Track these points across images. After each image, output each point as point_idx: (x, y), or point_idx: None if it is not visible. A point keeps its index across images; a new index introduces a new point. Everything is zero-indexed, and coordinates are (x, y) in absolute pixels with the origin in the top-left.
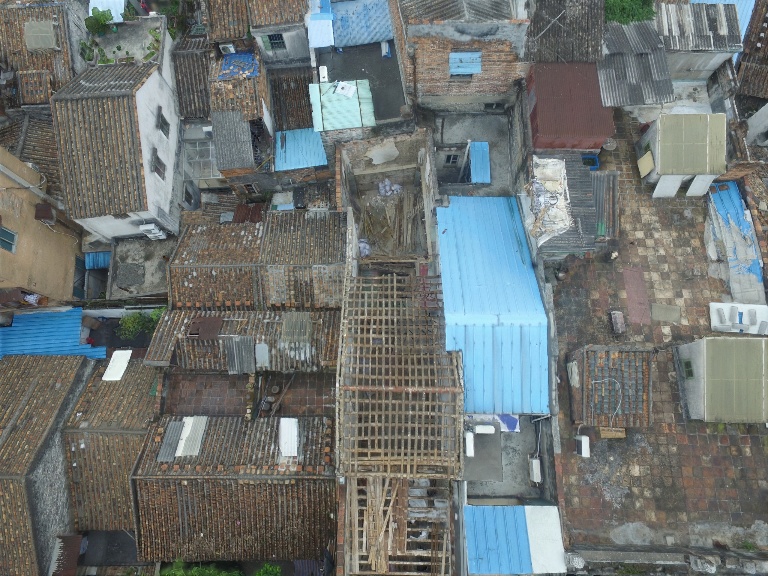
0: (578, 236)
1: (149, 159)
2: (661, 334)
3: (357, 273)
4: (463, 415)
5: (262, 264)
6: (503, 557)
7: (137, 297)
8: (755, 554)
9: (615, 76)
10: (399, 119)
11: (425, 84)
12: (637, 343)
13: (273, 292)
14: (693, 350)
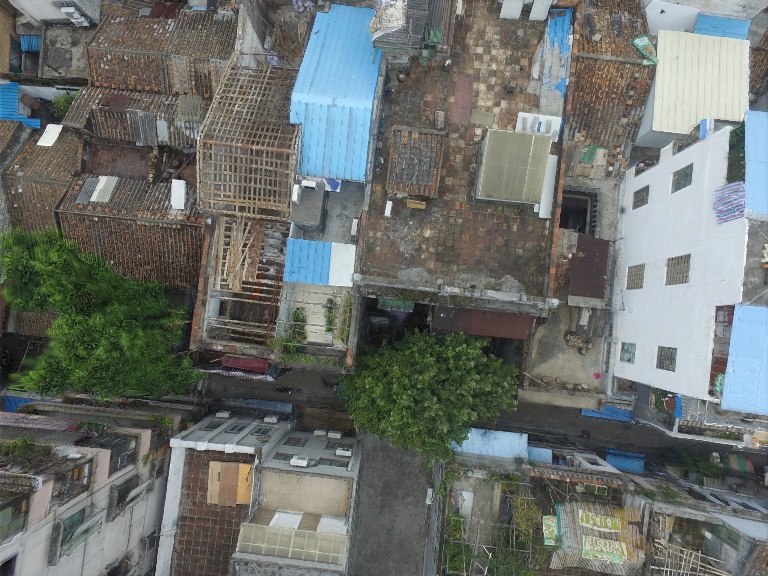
0: (407, 35)
1: None
2: (473, 134)
3: None
4: (294, 172)
5: (167, 53)
6: (309, 273)
7: (63, 76)
8: None
9: None
10: None
11: None
12: (452, 139)
13: (177, 81)
14: (484, 142)
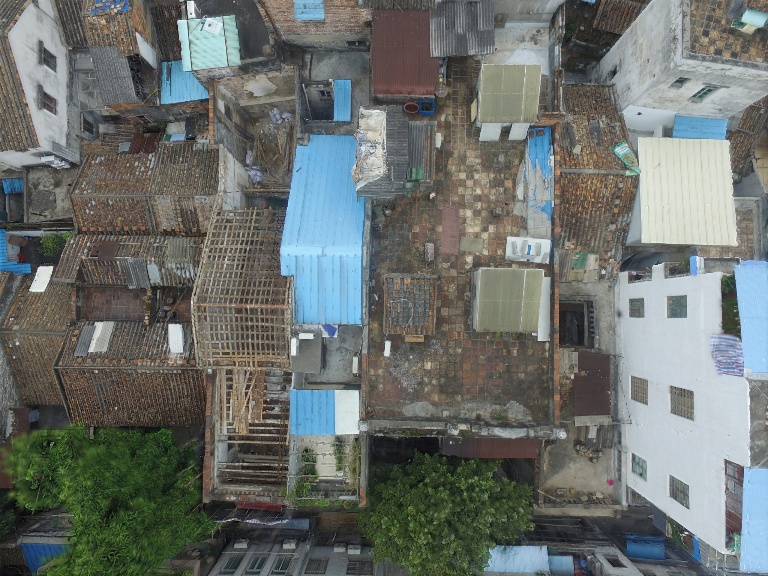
0: (389, 182)
1: (35, 97)
2: (464, 262)
3: (244, 200)
4: (290, 325)
5: (151, 195)
6: (315, 424)
7: (49, 222)
8: (498, 423)
9: (445, 25)
10: (262, 59)
11: (283, 24)
12: (443, 269)
13: (163, 219)
14: (477, 277)
